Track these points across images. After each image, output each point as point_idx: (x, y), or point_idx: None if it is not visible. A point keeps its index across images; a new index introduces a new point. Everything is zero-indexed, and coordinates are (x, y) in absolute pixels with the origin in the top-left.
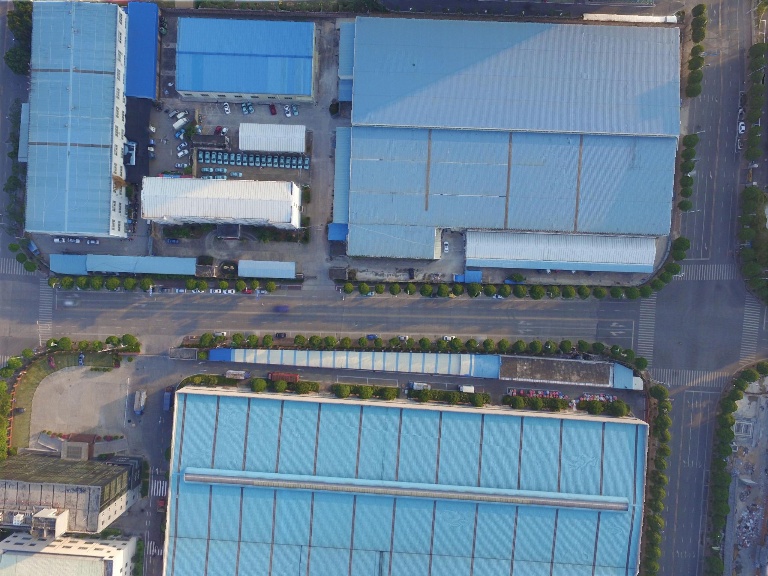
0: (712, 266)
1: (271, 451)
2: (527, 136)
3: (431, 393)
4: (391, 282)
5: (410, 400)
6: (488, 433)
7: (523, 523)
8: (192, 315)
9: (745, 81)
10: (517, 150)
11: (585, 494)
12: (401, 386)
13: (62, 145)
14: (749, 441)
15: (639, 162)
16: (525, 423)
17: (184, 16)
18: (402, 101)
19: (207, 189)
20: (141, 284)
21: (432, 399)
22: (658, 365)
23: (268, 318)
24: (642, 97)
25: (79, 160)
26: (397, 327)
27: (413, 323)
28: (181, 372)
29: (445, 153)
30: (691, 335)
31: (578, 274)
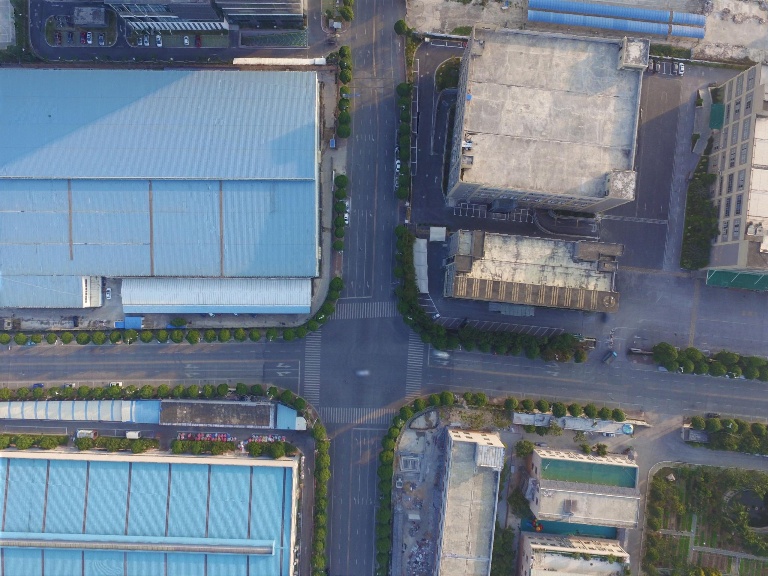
0: (375, 304)
1: None
2: (166, 183)
3: (92, 441)
4: (53, 331)
5: (75, 448)
6: (136, 481)
7: (173, 569)
8: None
9: None
10: (157, 197)
11: (232, 538)
12: (70, 434)
13: None
14: (416, 476)
15: (280, 206)
16: (173, 469)
17: None
18: (37, 153)
19: None
20: None
21: None
22: (325, 404)
23: None
24: (277, 141)
25: None
26: (64, 375)
27: (80, 370)
28: None
29: (86, 203)
30: (356, 373)
31: (243, 316)
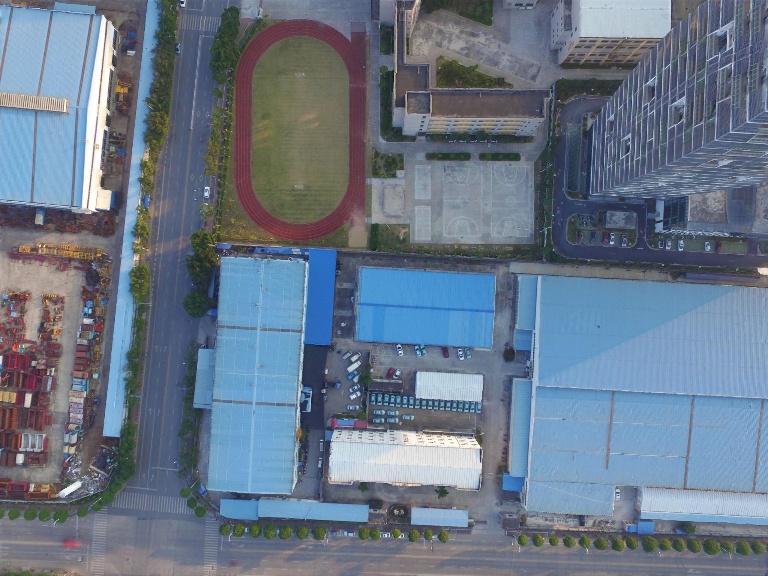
0: None
1: None
2: (709, 399)
3: None
4: (563, 530)
5: None
6: None
7: None
8: (360, 558)
9: None
10: (699, 412)
11: None
12: None
13: (247, 404)
14: None
15: None
16: None
17: (358, 256)
18: (587, 364)
19: (396, 455)
20: (316, 536)
21: None
22: None
23: (436, 562)
24: None
25: (264, 419)
26: (566, 573)
27: (582, 569)
28: None
29: (627, 414)
30: None
31: None
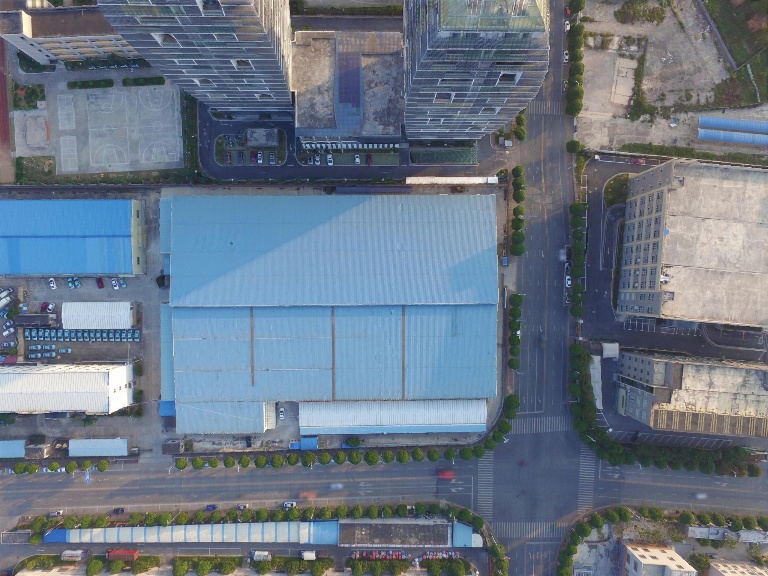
0: (546, 418)
1: None
2: (349, 309)
3: (270, 564)
4: (227, 452)
5: (251, 570)
6: None
7: None
8: (27, 495)
9: (570, 235)
10: (340, 323)
11: None
12: (244, 555)
13: None
14: None
15: (462, 329)
16: None
17: (4, 191)
18: (220, 281)
19: (21, 383)
20: None
21: (273, 569)
22: (498, 519)
23: (105, 493)
24: (460, 266)
25: None
26: (237, 495)
27: (253, 490)
28: (17, 554)
29: (268, 329)
30: (529, 488)
31: (415, 433)
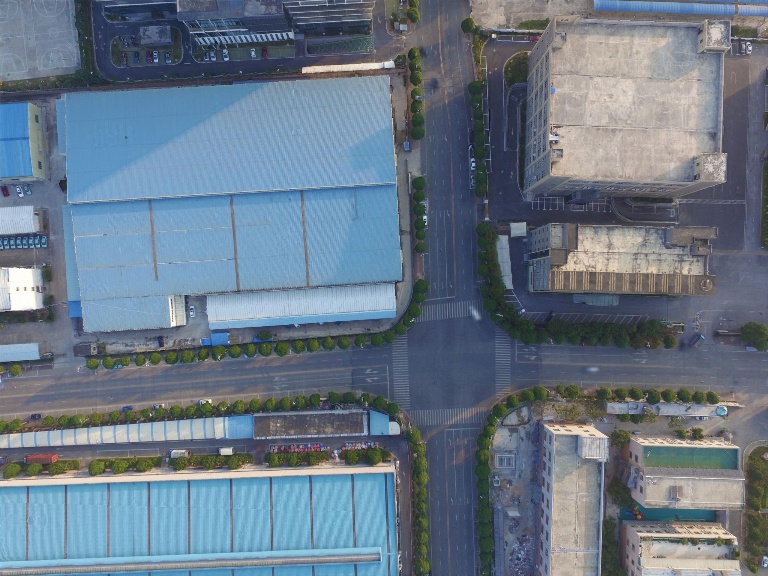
0: (459, 303)
1: None
2: (247, 197)
3: (187, 460)
4: (139, 352)
5: (170, 468)
6: (237, 497)
7: None
8: None
9: (472, 118)
10: (239, 212)
11: (339, 548)
12: (162, 455)
13: None
14: (512, 473)
15: (362, 212)
16: (274, 483)
17: None
18: (117, 175)
19: None
20: None
21: (190, 466)
22: (416, 407)
23: (22, 400)
24: (356, 148)
25: None
26: (152, 396)
27: (168, 390)
28: None
29: (168, 222)
30: (445, 374)
31: (328, 325)
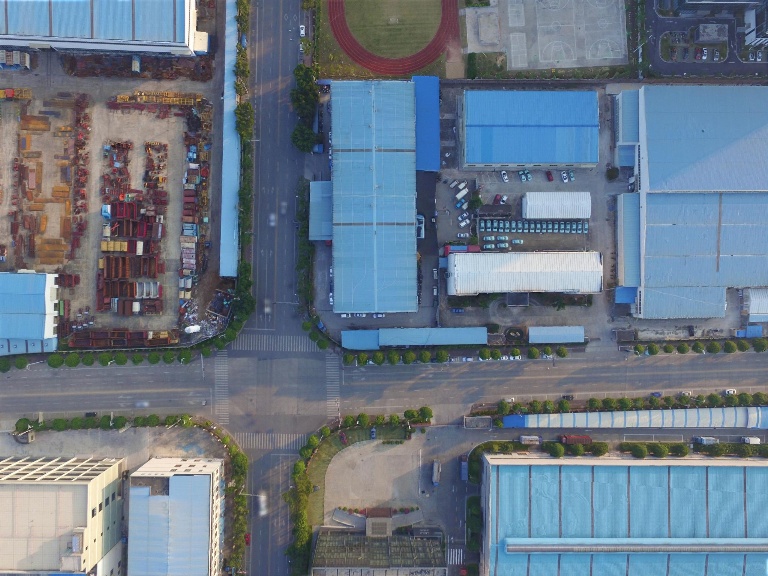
0: None
1: (577, 515)
2: None
3: None
4: (674, 340)
5: (699, 454)
6: None
7: None
8: (479, 383)
9: None
10: None
11: None
12: (686, 441)
13: (368, 225)
14: None
15: None
16: None
17: (457, 86)
18: (695, 167)
19: (519, 263)
20: (440, 357)
21: None
22: None
23: (554, 381)
24: None
25: (385, 239)
26: (679, 383)
27: (694, 379)
28: (472, 440)
29: (735, 215)
30: None
31: None
